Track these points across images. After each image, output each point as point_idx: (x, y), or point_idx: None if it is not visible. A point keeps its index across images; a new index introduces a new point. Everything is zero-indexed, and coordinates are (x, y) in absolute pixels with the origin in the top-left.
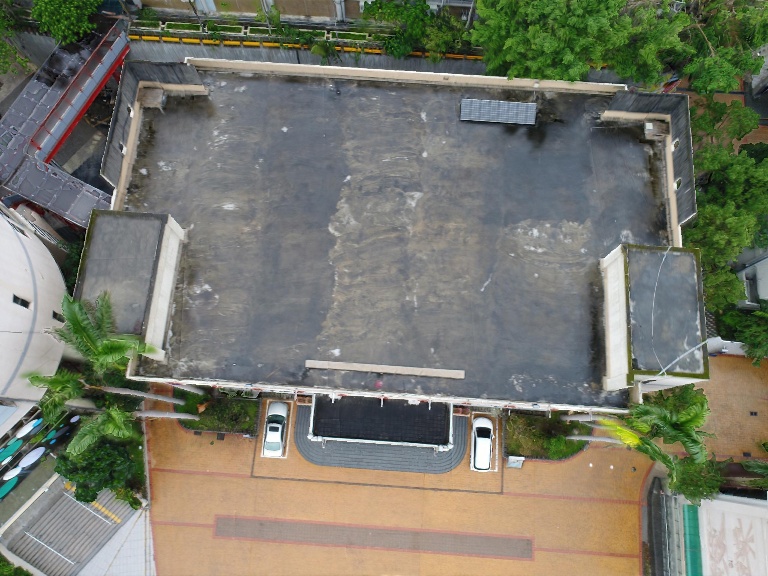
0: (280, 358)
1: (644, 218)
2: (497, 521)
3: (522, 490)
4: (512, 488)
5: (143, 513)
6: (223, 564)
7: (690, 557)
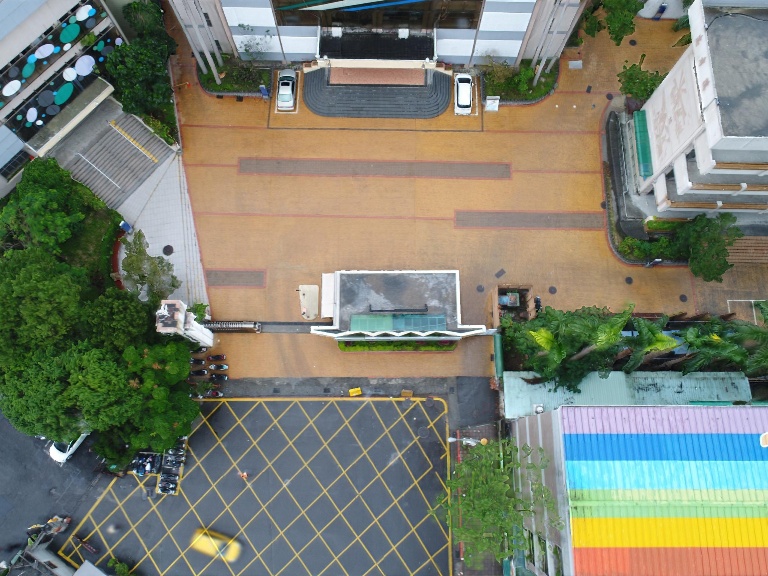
0: None
1: None
2: (479, 152)
3: (499, 128)
4: (491, 127)
5: (176, 157)
6: (247, 193)
7: (641, 147)
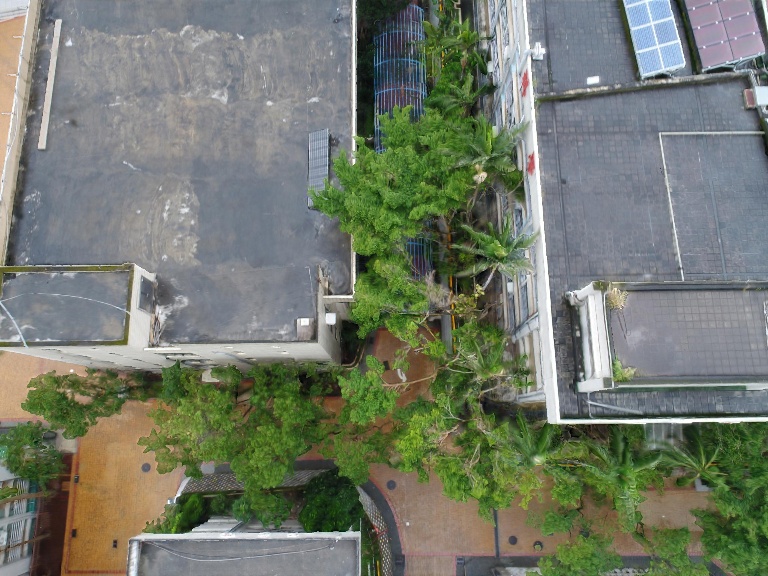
0: (66, 0)
1: (203, 321)
2: None
3: None
4: None
5: None
6: (8, 67)
7: None
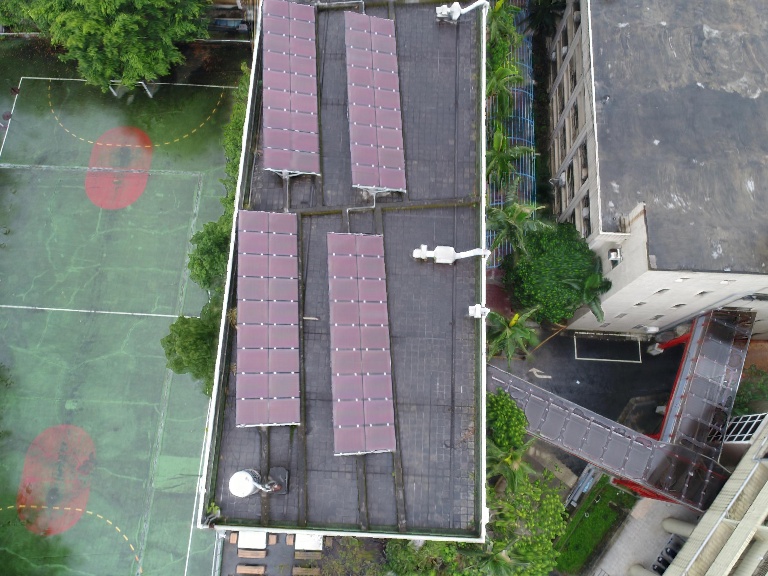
0: None
1: None
2: None
3: None
4: None
5: None
6: None
7: None
